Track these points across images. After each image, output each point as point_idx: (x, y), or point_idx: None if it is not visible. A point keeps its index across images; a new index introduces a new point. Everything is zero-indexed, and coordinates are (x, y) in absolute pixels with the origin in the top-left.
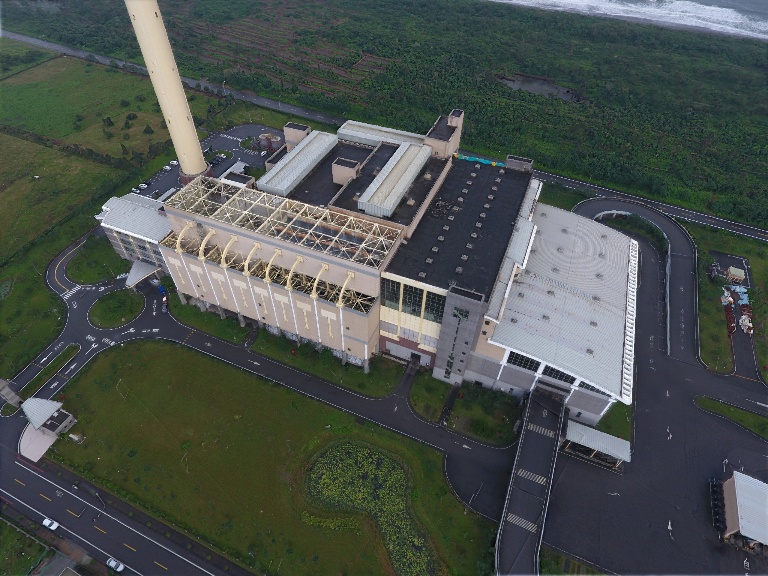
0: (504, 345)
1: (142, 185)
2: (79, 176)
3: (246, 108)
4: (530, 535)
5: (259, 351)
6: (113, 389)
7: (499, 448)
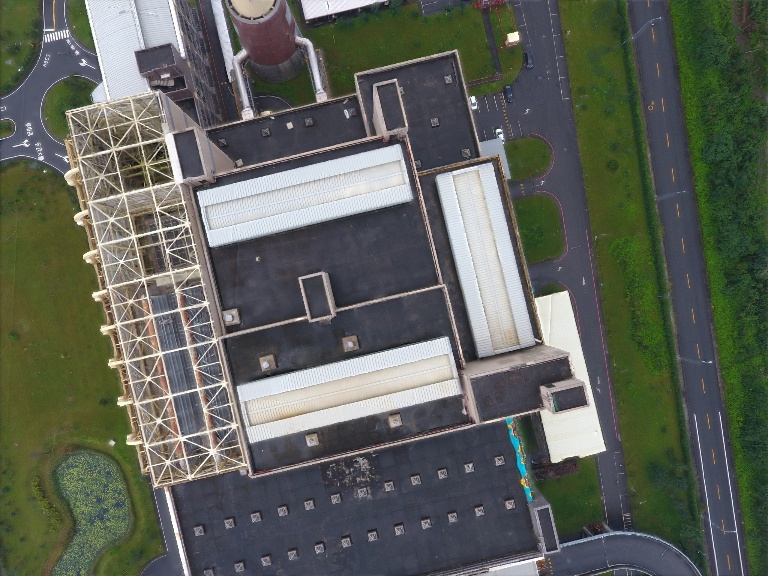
0: None
1: None
2: None
3: None
4: None
5: None
6: (6, 217)
7: None
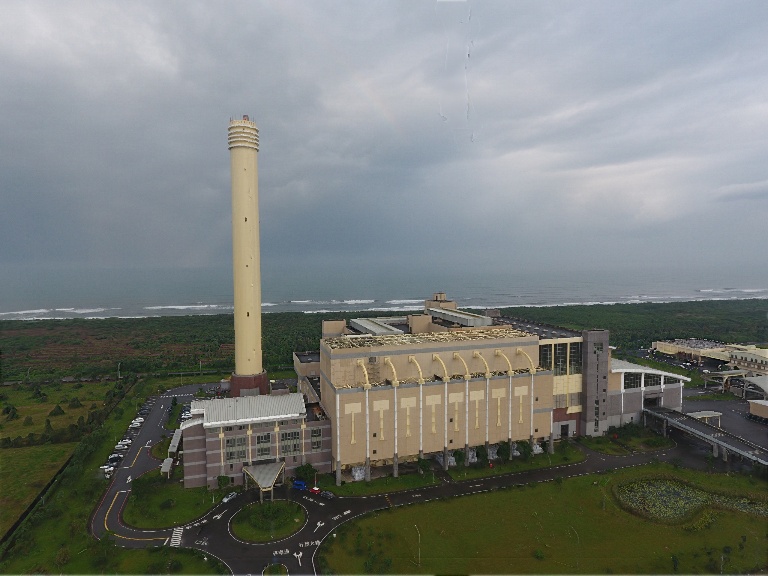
0: (621, 369)
1: (125, 441)
2: (3, 461)
3: (161, 379)
4: (766, 455)
5: (465, 478)
6: (391, 568)
7: (675, 447)
